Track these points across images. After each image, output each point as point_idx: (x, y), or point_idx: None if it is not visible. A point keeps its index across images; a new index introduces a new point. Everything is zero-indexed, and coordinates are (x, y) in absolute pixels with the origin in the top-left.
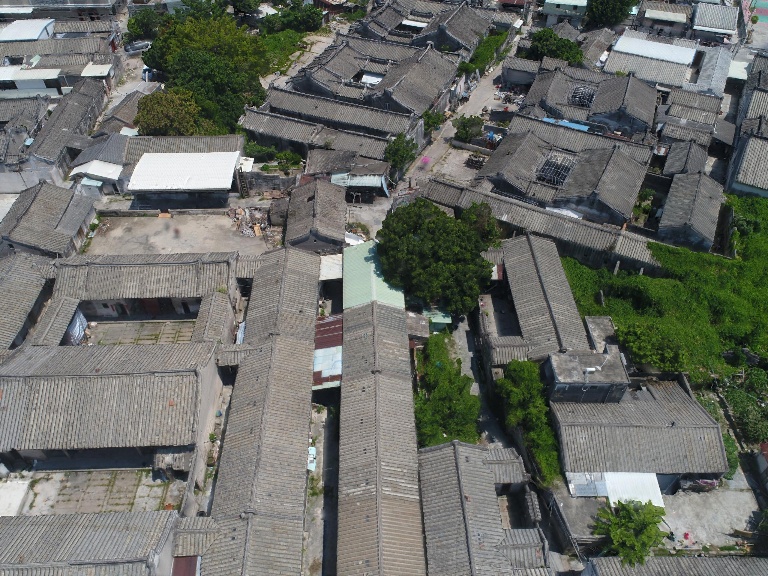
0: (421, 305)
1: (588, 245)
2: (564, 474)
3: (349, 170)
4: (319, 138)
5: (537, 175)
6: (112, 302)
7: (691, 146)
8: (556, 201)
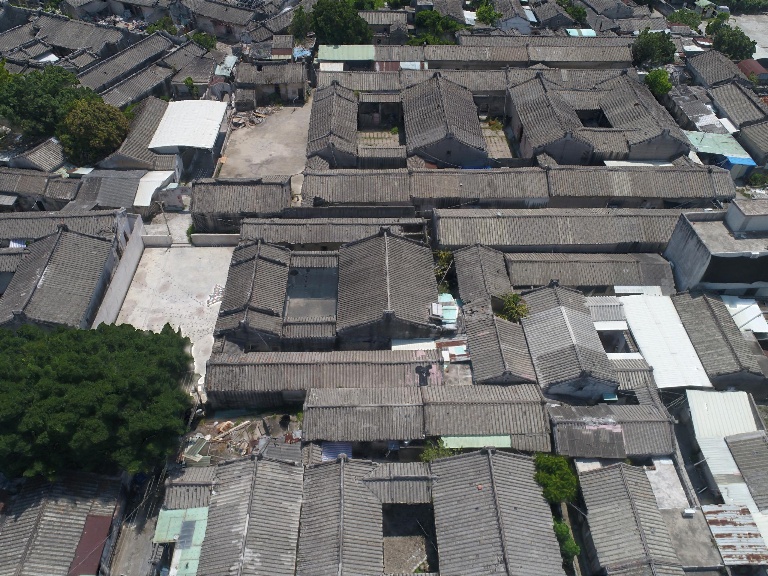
0: None
1: None
2: (467, 24)
3: (216, 63)
4: (159, 74)
5: (252, 7)
6: None
7: None
8: (280, 7)
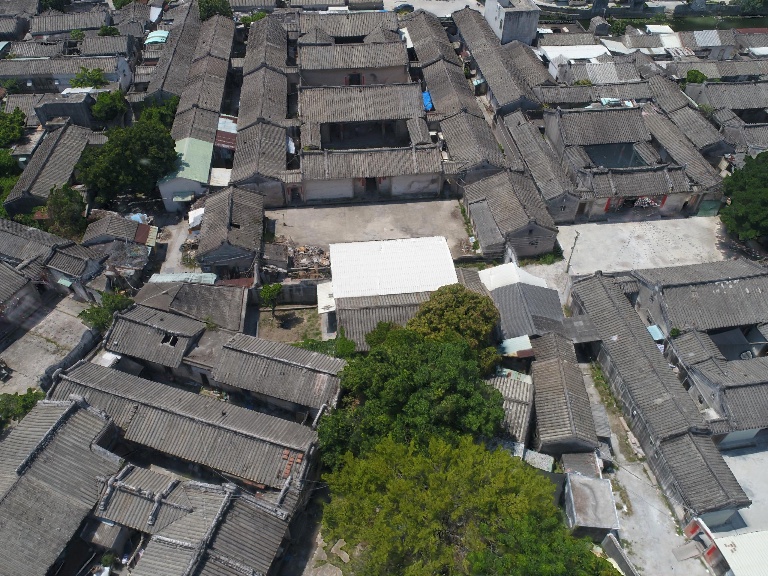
0: None
1: None
2: None
3: None
4: None
5: None
6: None
7: None
8: None
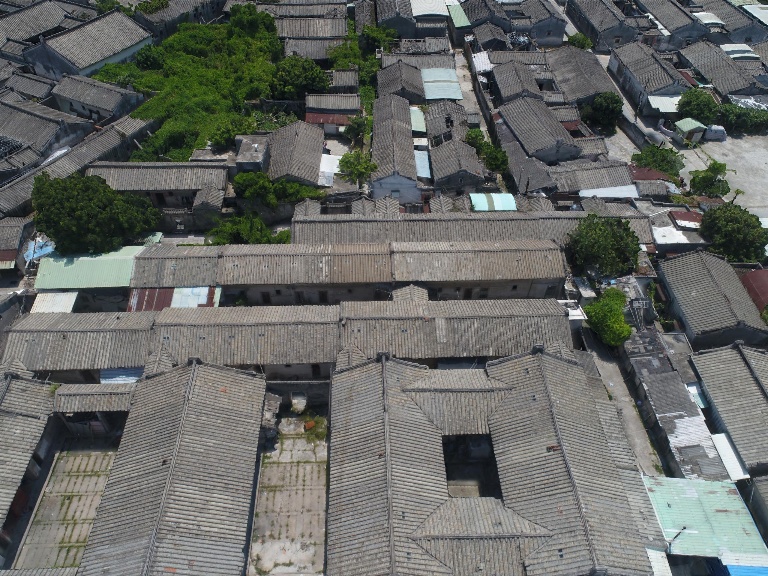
0: (137, 245)
1: (111, 147)
2: (318, 186)
3: None
4: None
5: None
6: None
7: (21, 74)
8: (43, 153)
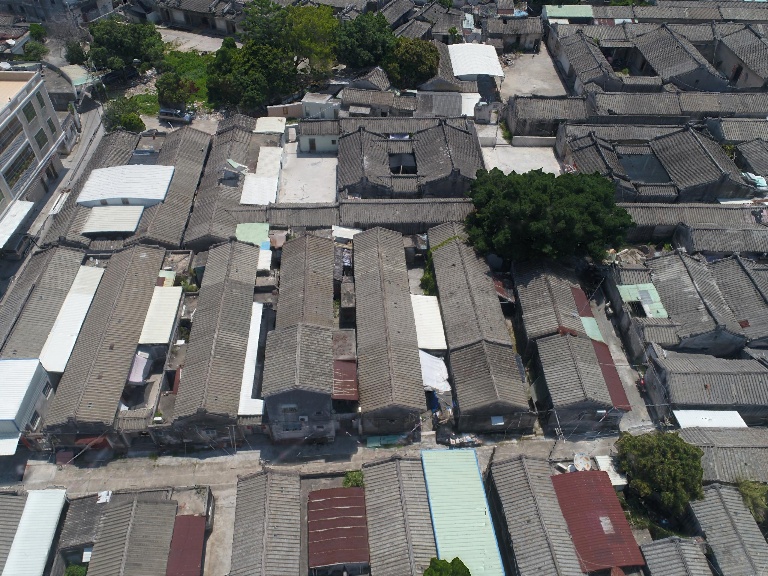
0: None
1: None
2: None
3: None
4: None
5: None
6: None
7: None
8: None
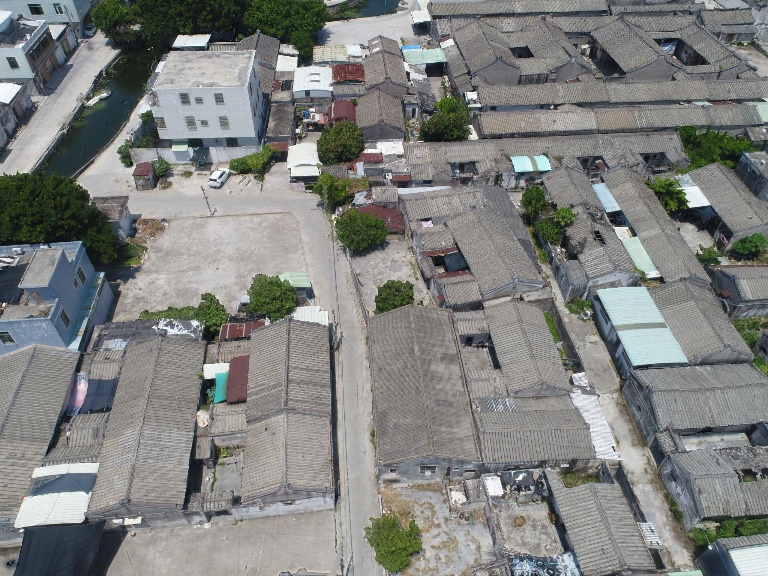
0: None
1: None
2: None
3: None
4: None
5: None
6: (689, 51)
7: None
8: None
